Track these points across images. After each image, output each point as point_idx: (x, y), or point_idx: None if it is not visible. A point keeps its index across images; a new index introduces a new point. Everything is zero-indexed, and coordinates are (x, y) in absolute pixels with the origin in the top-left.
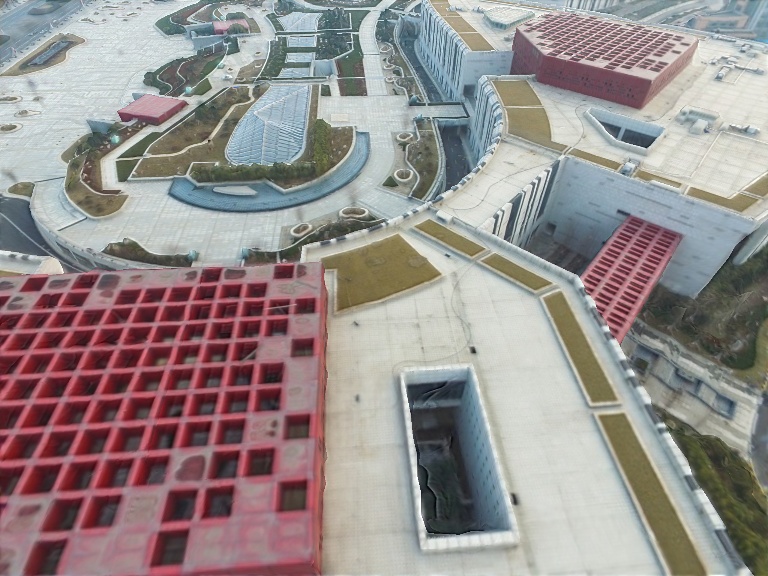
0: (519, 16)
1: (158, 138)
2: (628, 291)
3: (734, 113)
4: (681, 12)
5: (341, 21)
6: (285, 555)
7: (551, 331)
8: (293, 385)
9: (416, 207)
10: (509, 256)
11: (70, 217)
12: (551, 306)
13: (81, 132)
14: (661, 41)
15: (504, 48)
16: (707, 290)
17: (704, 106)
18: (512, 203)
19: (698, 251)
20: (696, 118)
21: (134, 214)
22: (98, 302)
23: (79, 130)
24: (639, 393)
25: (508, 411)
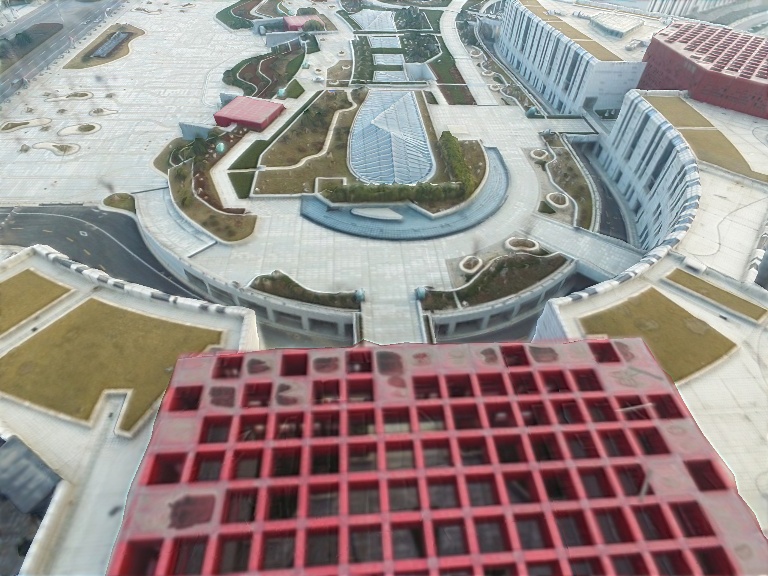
0: (631, 24)
1: (267, 147)
2: None
3: None
4: (759, 24)
5: (423, 21)
6: None
7: None
8: (735, 541)
9: (587, 239)
10: None
11: (195, 240)
12: None
13: (169, 136)
14: None
15: (631, 58)
16: None
17: None
18: (764, 250)
19: None
20: None
21: (270, 239)
22: (392, 395)
23: (166, 133)
24: None
25: None
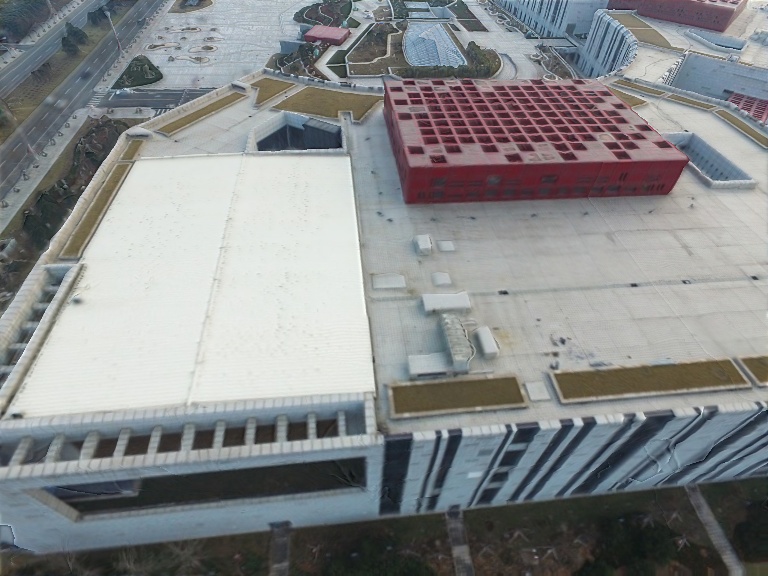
0: None
1: (348, 53)
2: None
3: None
4: None
5: None
6: (676, 157)
7: (727, 124)
8: None
9: None
10: None
11: None
12: (722, 115)
13: (269, 52)
14: None
15: None
16: None
17: None
18: (669, 72)
19: None
20: (765, 37)
21: None
22: None
23: (266, 51)
24: None
25: (722, 151)
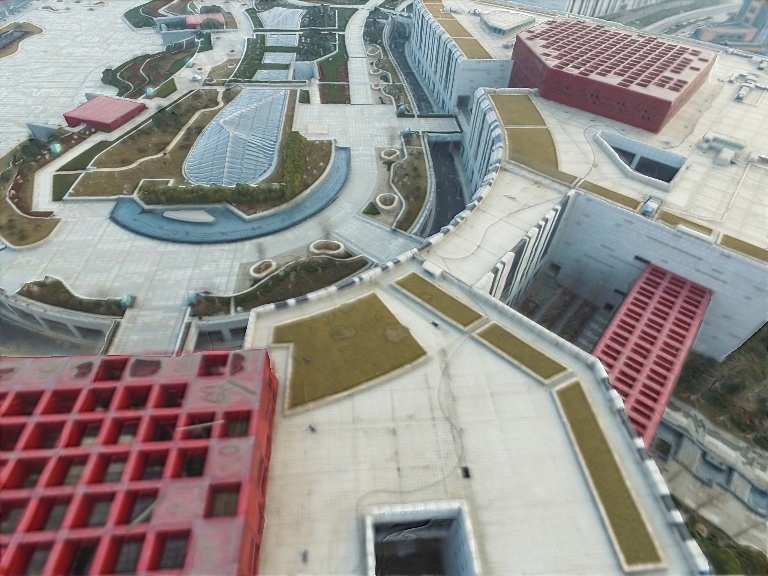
0: (519, 21)
1: (107, 148)
2: (654, 368)
3: (761, 141)
4: (684, 22)
5: (326, 19)
6: None
7: (568, 443)
8: (200, 573)
9: (400, 241)
10: (511, 326)
11: None
12: (566, 404)
13: (22, 136)
14: (677, 55)
15: (503, 56)
16: (735, 351)
17: (727, 131)
18: (514, 253)
19: (730, 310)
20: (720, 146)
21: (64, 243)
22: None
23: (20, 134)
24: (691, 553)
25: None
